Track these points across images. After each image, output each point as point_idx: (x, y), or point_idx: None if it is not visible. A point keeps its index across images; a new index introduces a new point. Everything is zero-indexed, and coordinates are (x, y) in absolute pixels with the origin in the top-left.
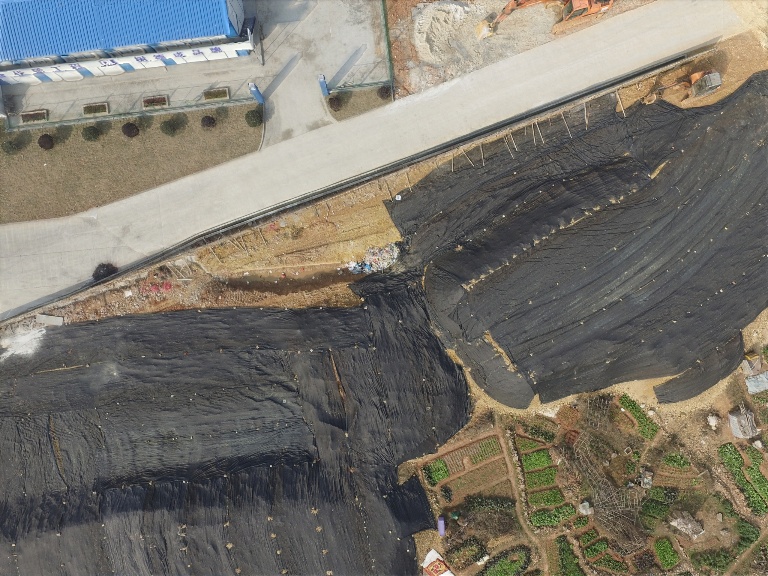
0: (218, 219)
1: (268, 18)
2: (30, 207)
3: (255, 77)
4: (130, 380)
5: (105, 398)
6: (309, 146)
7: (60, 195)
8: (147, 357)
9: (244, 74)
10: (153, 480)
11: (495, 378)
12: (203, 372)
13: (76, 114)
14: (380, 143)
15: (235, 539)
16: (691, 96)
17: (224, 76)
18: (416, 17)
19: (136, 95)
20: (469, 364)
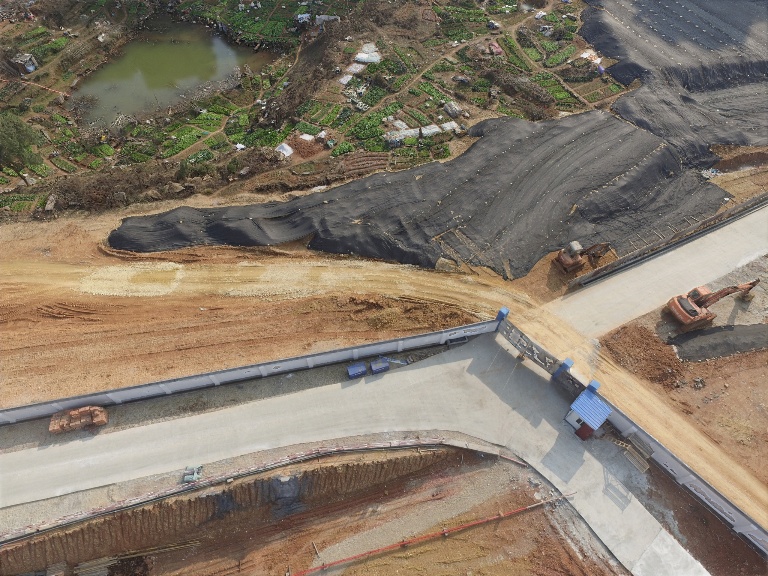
0: None
1: None
2: None
3: None
4: None
5: None
6: None
7: None
8: None
9: None
10: (764, 76)
11: None
12: None
13: None
14: (763, 226)
15: (712, 53)
16: None
17: None
18: None
19: None
20: None
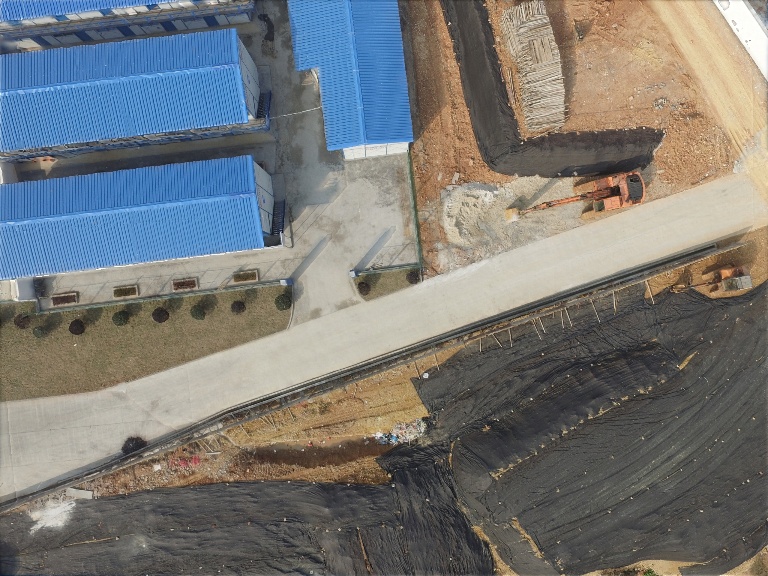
0: (246, 395)
1: (297, 200)
2: (60, 383)
3: (284, 259)
4: (159, 553)
5: (134, 570)
6: (337, 325)
7: (90, 372)
8: (176, 530)
9: (273, 256)
10: None
11: (522, 559)
12: (231, 544)
13: (106, 296)
14: (408, 322)
15: None
16: (721, 289)
17: (253, 258)
18: (445, 199)
19: (166, 277)
20: (495, 542)
